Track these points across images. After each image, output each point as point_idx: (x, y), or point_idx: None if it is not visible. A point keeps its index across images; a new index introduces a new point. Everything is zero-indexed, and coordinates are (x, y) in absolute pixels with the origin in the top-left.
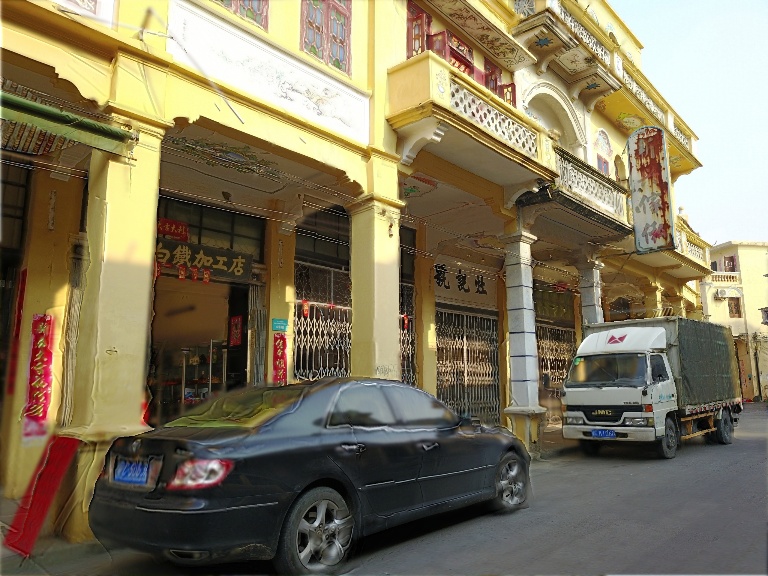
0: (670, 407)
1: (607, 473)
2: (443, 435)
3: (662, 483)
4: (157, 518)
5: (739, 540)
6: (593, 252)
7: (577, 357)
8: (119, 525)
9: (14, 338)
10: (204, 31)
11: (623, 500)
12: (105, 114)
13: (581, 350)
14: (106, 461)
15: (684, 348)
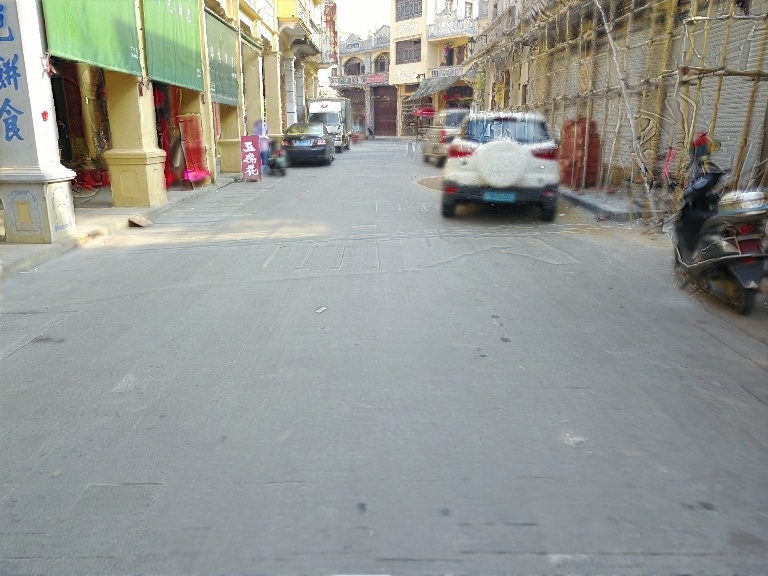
0: None
1: None
2: (331, 138)
3: None
4: (316, 151)
5: (387, 159)
6: (302, 60)
7: (310, 113)
8: (304, 153)
9: (177, 105)
10: None
11: None
12: None
13: (311, 110)
14: (290, 142)
15: None
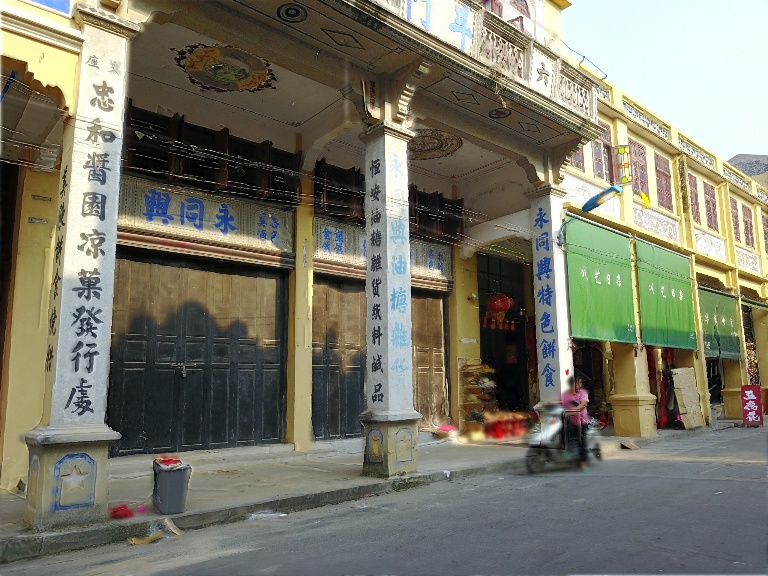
0: None
1: None
2: None
3: None
4: None
5: None
6: None
7: None
8: None
9: None
10: (767, 265)
11: None
12: (764, 300)
13: None
14: None
15: None
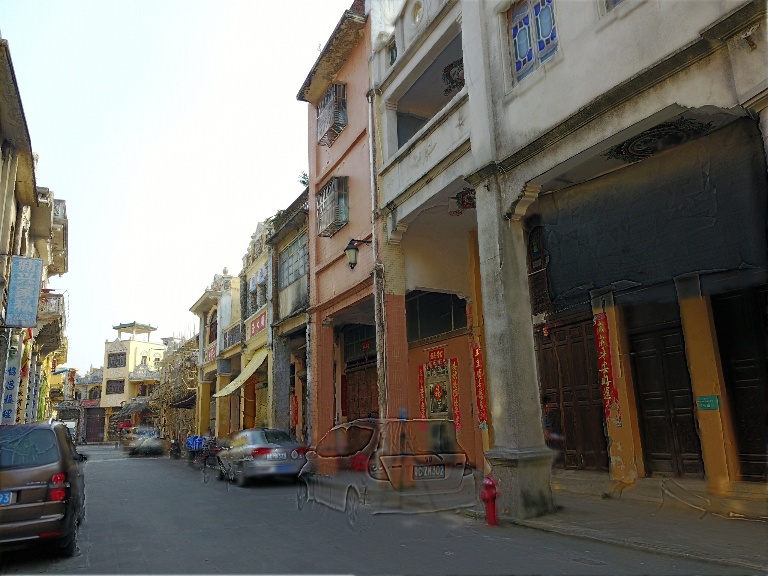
0: None
1: None
2: None
3: None
4: None
5: None
6: None
7: None
8: None
9: None
10: None
11: None
12: None
13: None
14: None
15: None
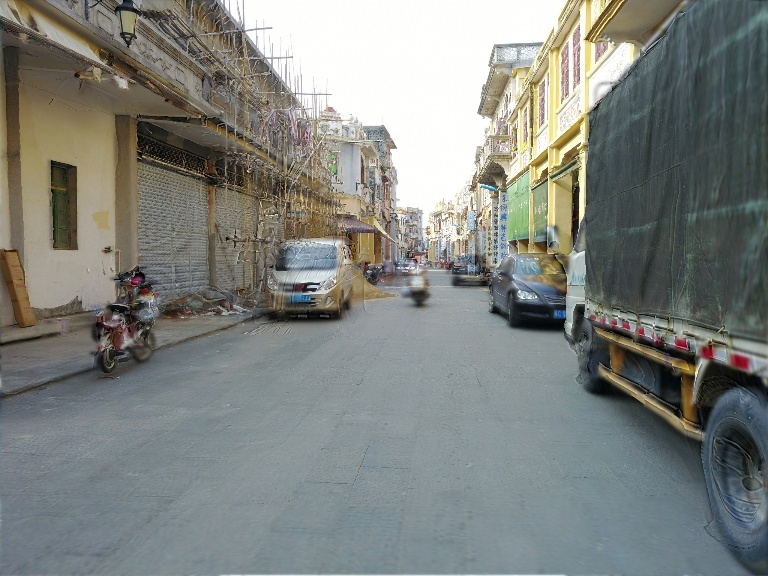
0: (581, 296)
1: (561, 351)
2: None
3: (489, 345)
4: None
5: None
6: None
7: None
8: None
9: None
10: None
11: (479, 332)
12: None
13: None
14: None
15: (591, 176)
